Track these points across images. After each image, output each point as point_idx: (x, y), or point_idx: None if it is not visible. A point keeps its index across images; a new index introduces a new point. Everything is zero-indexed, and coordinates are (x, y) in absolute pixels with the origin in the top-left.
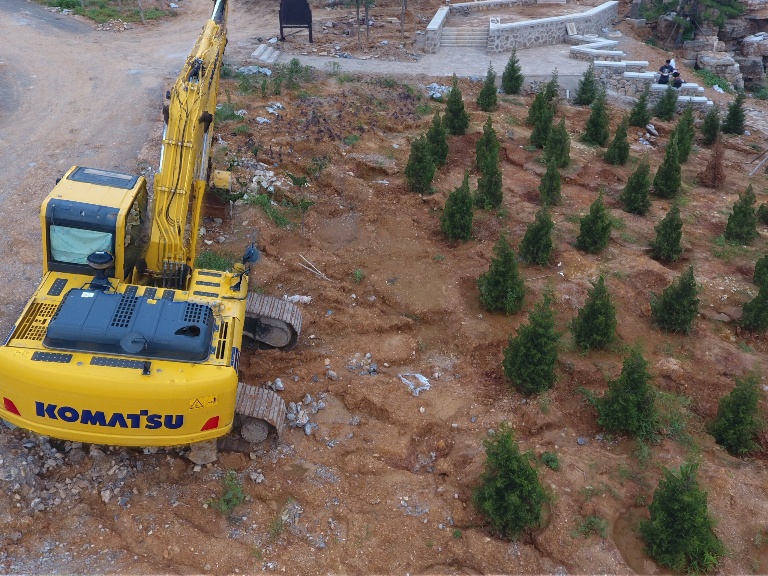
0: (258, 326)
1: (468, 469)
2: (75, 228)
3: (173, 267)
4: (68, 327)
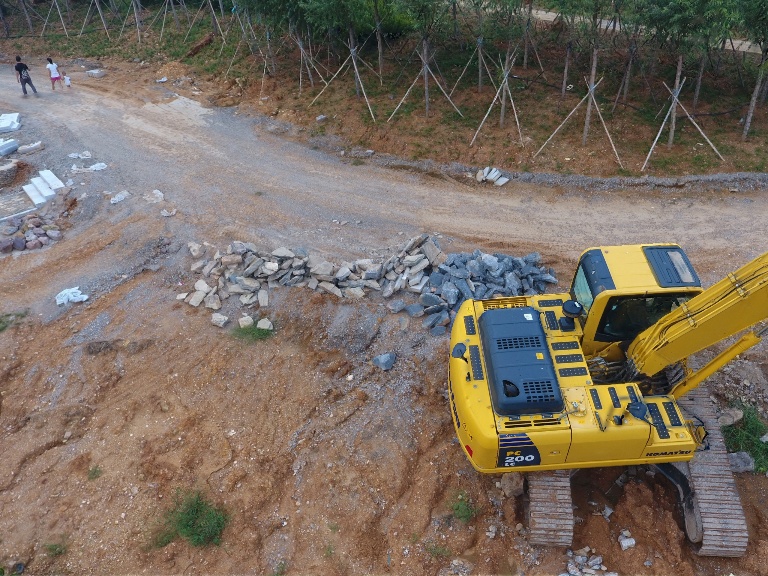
0: (689, 497)
1: None
2: (586, 278)
3: (633, 367)
4: (489, 319)
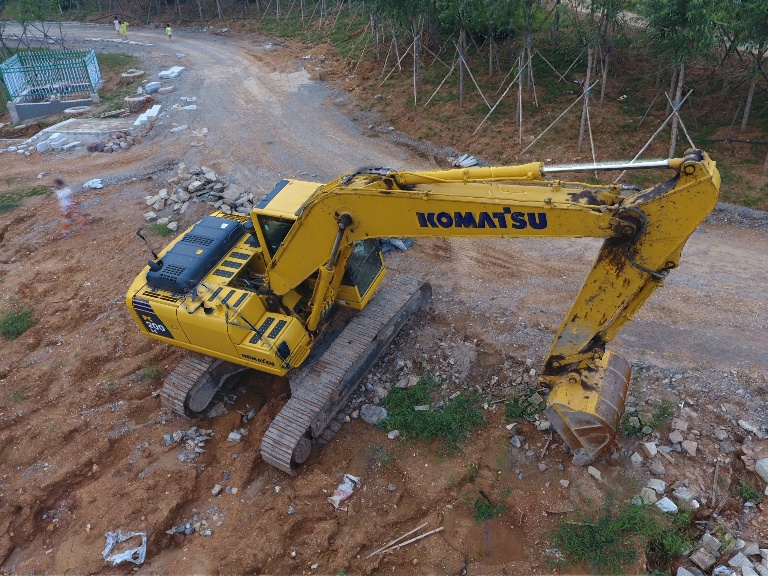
0: None
1: (6, 522)
2: None
3: None
4: None
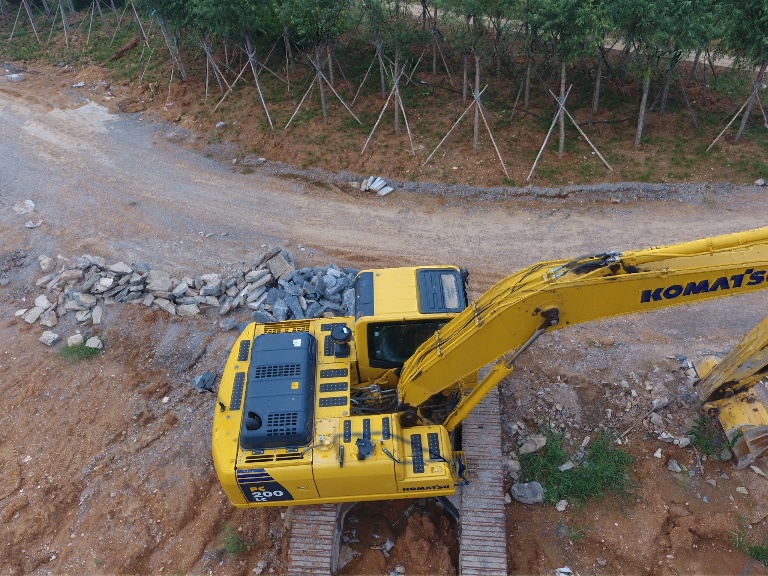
0: None
1: None
2: None
3: None
4: None
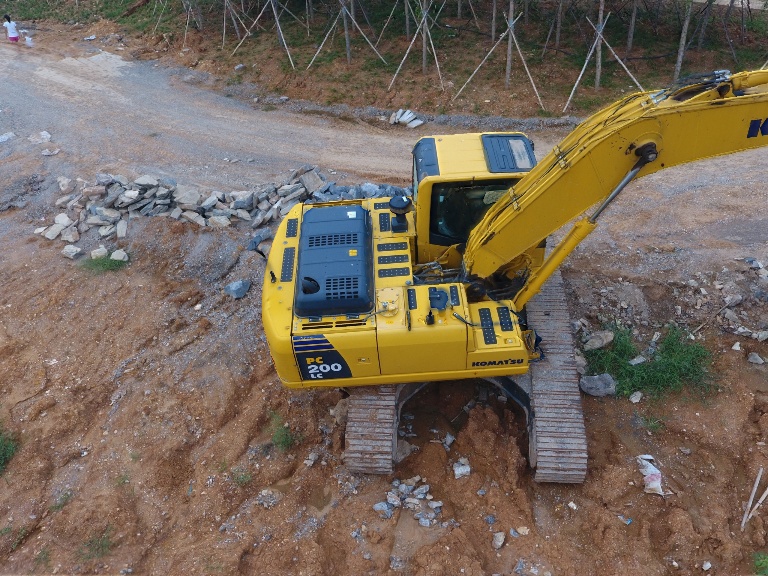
0: None
1: None
2: None
3: None
4: None
